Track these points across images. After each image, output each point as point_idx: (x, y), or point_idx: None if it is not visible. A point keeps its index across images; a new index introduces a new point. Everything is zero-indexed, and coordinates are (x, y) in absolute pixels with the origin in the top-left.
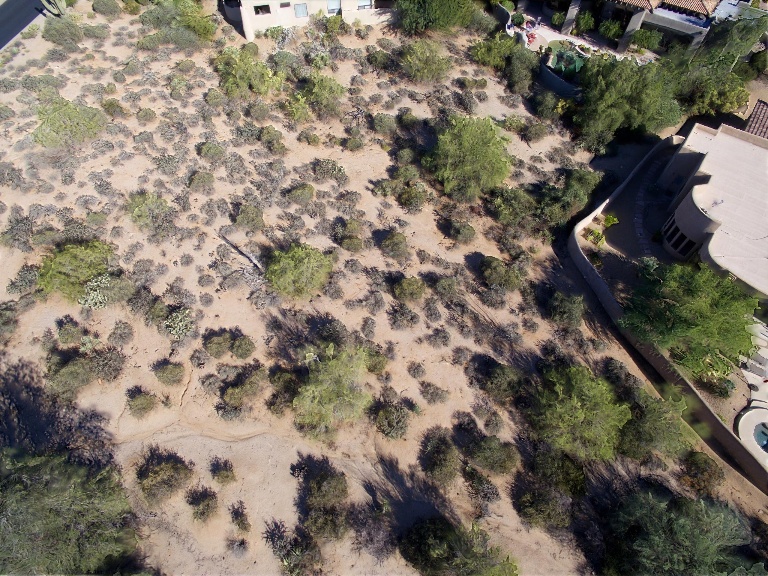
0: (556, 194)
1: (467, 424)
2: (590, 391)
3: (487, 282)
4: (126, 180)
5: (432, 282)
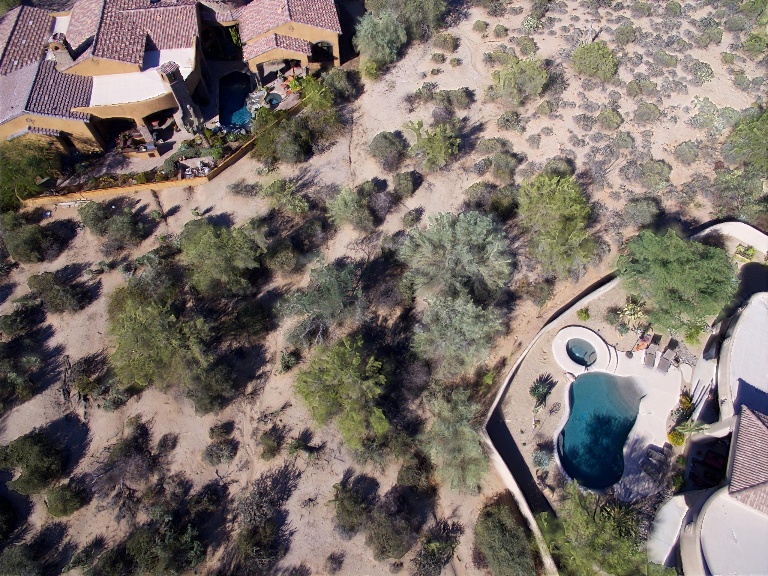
0: None
1: (520, 156)
2: None
3: None
4: None
5: None
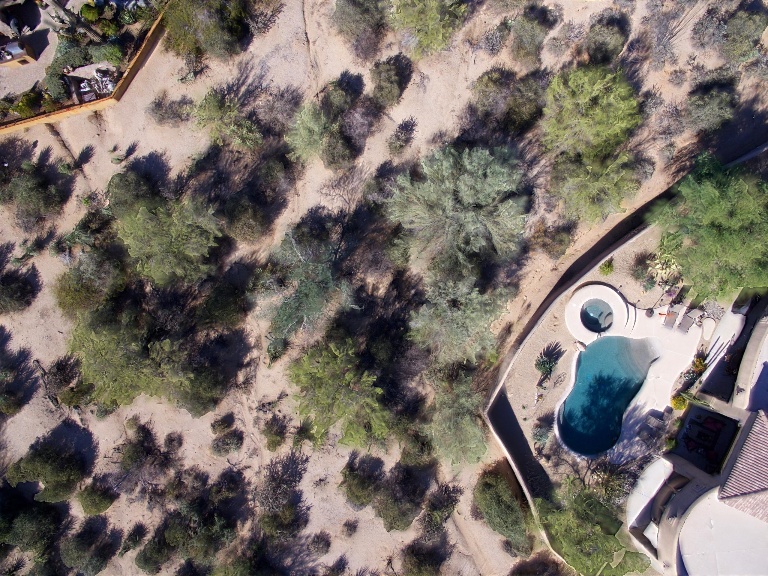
0: None
1: (552, 15)
2: None
3: None
4: None
5: None
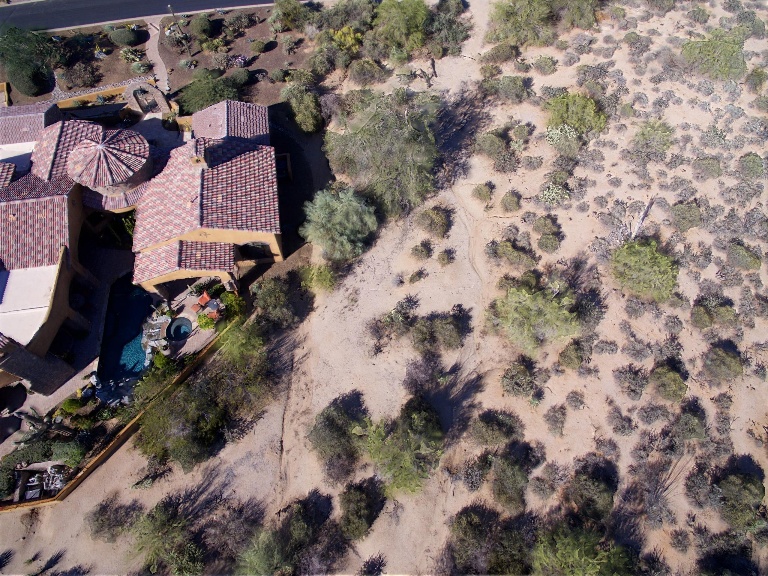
0: None
1: (534, 455)
2: None
3: None
4: (678, 115)
5: (690, 411)
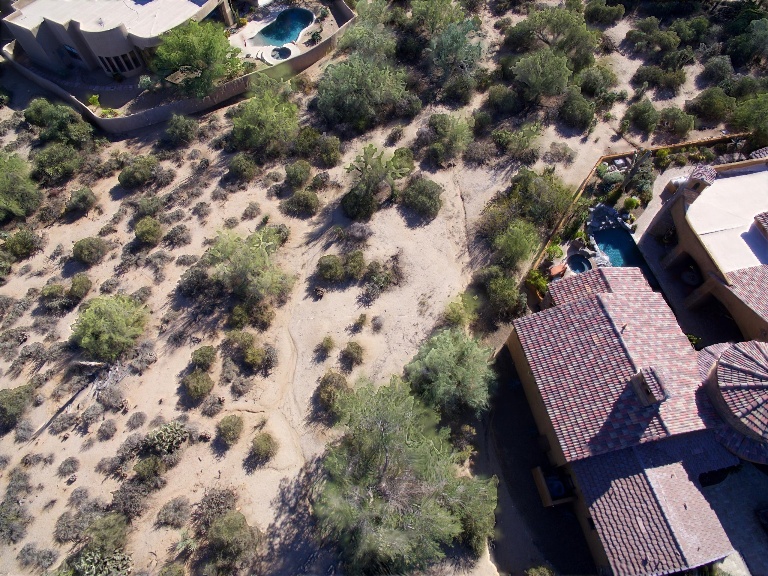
0: (56, 124)
1: (277, 189)
2: (255, 106)
3: (147, 183)
4: None
5: (141, 219)
